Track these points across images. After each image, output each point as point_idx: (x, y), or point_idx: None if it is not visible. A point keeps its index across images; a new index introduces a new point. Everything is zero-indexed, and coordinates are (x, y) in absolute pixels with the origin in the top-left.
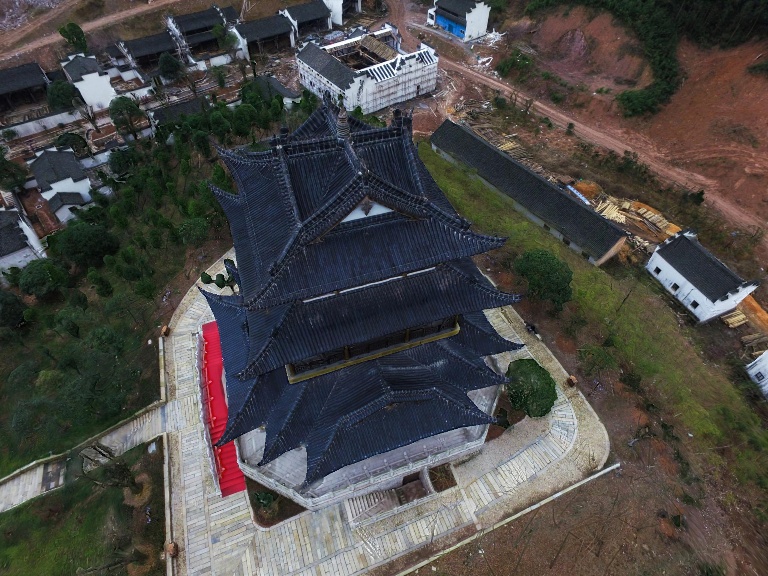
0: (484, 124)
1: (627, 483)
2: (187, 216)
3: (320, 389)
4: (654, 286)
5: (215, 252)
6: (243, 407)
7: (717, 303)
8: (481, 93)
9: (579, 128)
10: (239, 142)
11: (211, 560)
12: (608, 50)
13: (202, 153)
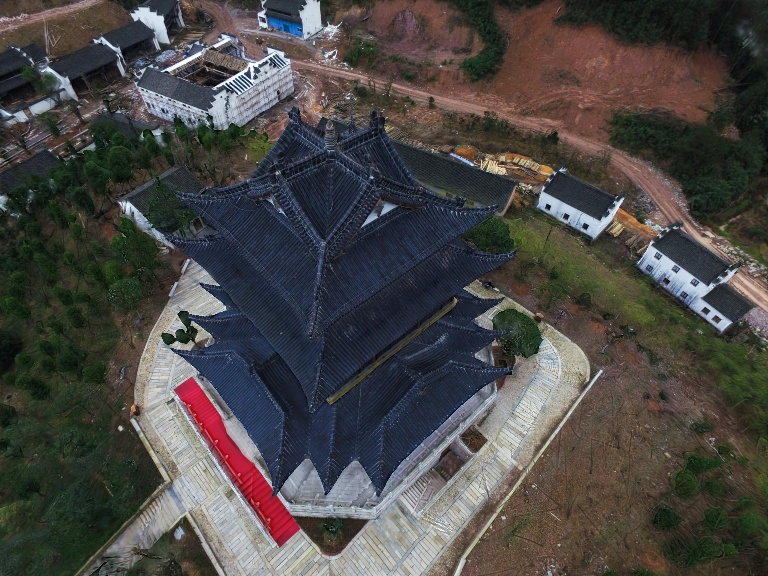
0: (354, 115)
1: (613, 383)
2: (101, 283)
3: (349, 401)
4: (549, 221)
5: (151, 311)
6: (282, 447)
7: (603, 220)
8: (339, 86)
9: (438, 100)
10: (121, 189)
11: None
12: (439, 25)
13: (86, 211)
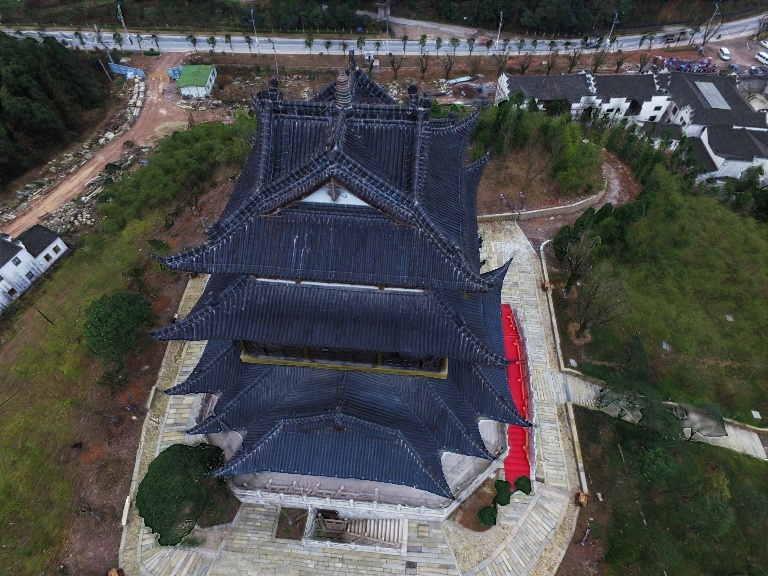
0: None
1: None
2: None
3: None
4: None
5: None
6: (488, 277)
7: None
8: None
9: None
10: None
11: (519, 275)
12: None
13: None
